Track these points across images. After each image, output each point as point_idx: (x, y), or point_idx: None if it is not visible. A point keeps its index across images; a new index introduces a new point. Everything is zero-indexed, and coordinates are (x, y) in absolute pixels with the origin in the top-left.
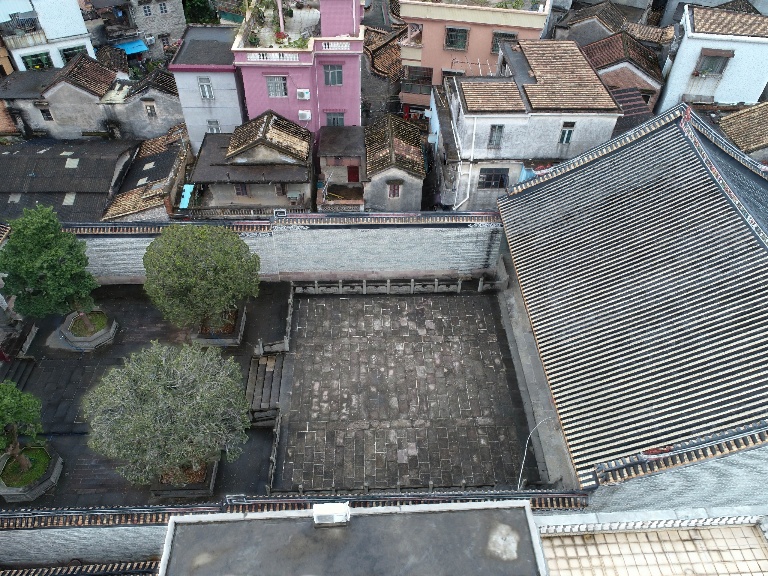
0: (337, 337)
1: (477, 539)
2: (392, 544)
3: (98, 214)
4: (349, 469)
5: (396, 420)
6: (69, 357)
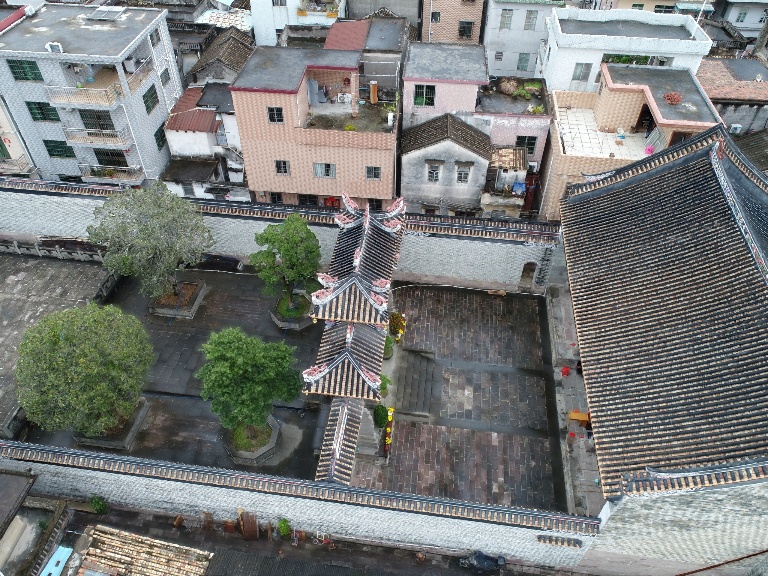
0: (0, 377)
1: (7, 46)
2: (40, 48)
3: (214, 571)
4: (64, 274)
5: (6, 298)
6: (276, 411)
